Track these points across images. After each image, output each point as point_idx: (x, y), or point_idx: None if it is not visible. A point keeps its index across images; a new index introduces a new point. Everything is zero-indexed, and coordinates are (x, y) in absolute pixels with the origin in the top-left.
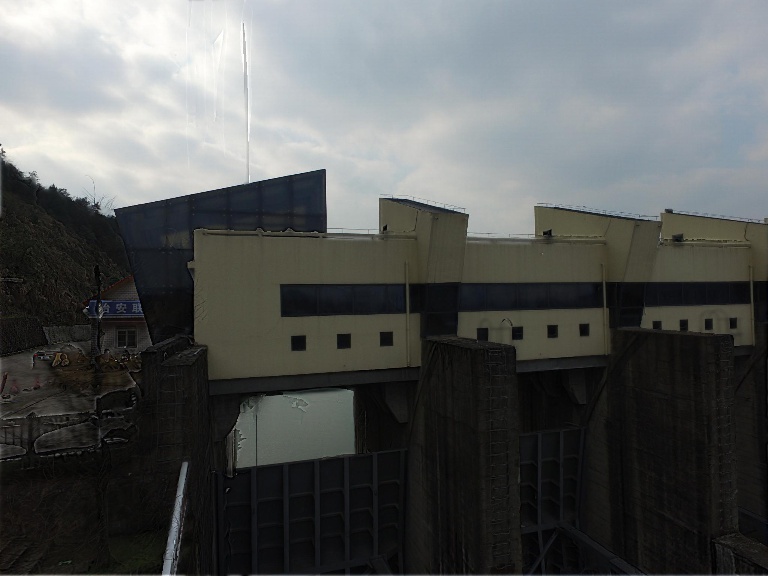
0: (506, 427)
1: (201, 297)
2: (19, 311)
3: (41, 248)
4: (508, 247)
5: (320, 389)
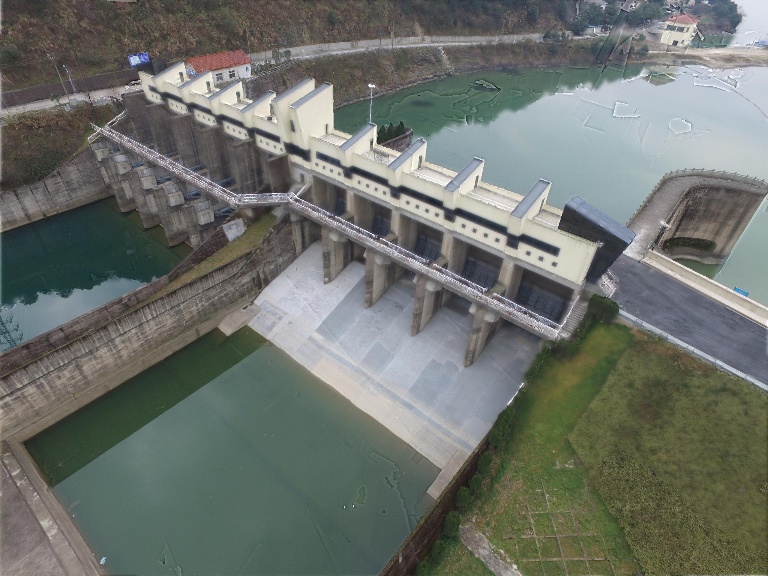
0: (149, 119)
1: (142, 84)
2: (227, 49)
3: (267, 6)
4: (171, 86)
5: (410, 111)
